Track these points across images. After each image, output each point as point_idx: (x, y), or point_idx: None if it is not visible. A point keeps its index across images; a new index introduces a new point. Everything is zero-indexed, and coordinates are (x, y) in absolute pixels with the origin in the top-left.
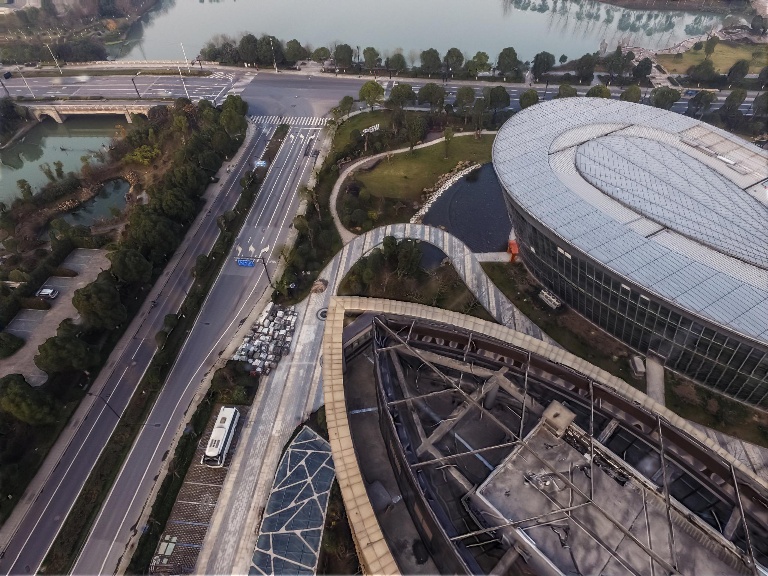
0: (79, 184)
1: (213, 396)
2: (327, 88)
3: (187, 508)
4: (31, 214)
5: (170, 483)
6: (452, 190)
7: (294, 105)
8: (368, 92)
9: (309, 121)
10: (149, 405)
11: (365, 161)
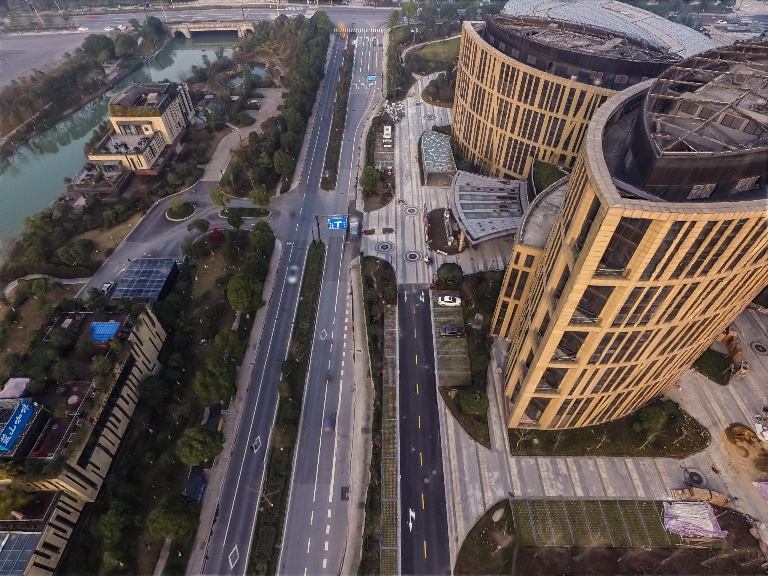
0: (233, 63)
1: (374, 129)
2: (372, 14)
3: (381, 158)
4: (215, 75)
5: (369, 151)
6: None
7: (354, 23)
8: (408, 9)
9: (368, 30)
10: (341, 134)
11: (415, 46)
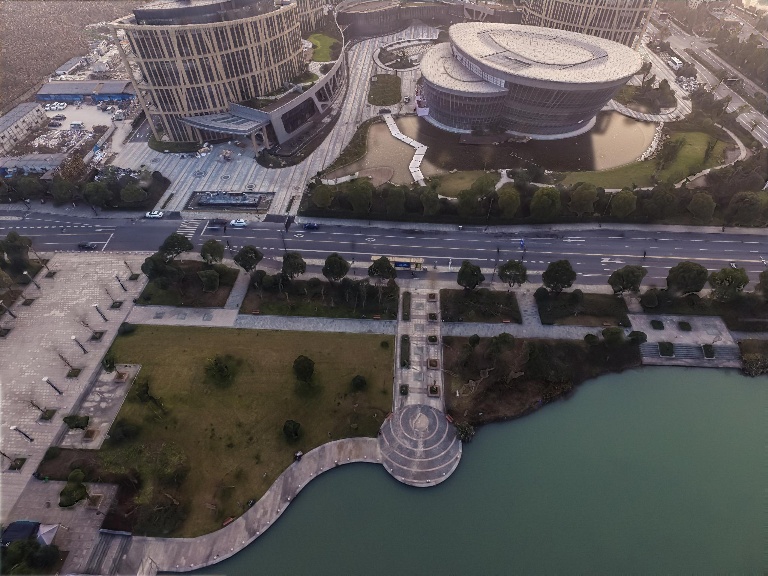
0: None
1: None
2: None
3: None
4: None
5: None
6: (648, 143)
7: None
8: None
9: None
10: None
11: (739, 158)
